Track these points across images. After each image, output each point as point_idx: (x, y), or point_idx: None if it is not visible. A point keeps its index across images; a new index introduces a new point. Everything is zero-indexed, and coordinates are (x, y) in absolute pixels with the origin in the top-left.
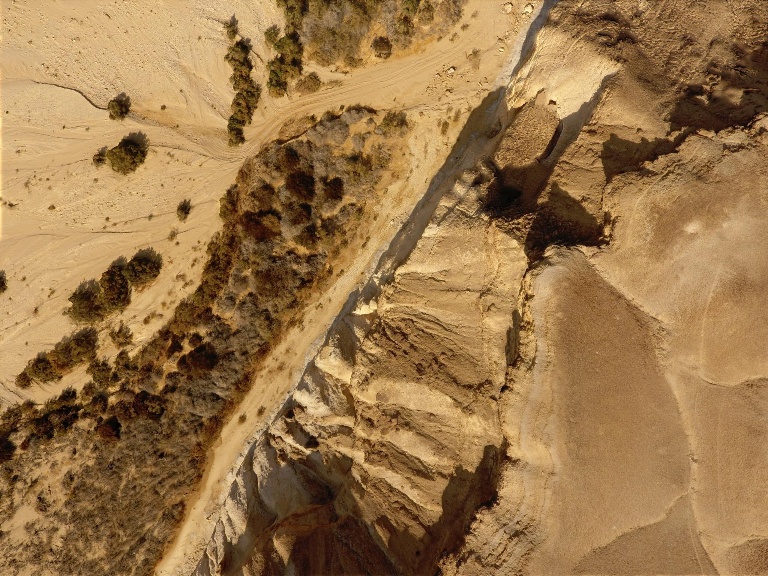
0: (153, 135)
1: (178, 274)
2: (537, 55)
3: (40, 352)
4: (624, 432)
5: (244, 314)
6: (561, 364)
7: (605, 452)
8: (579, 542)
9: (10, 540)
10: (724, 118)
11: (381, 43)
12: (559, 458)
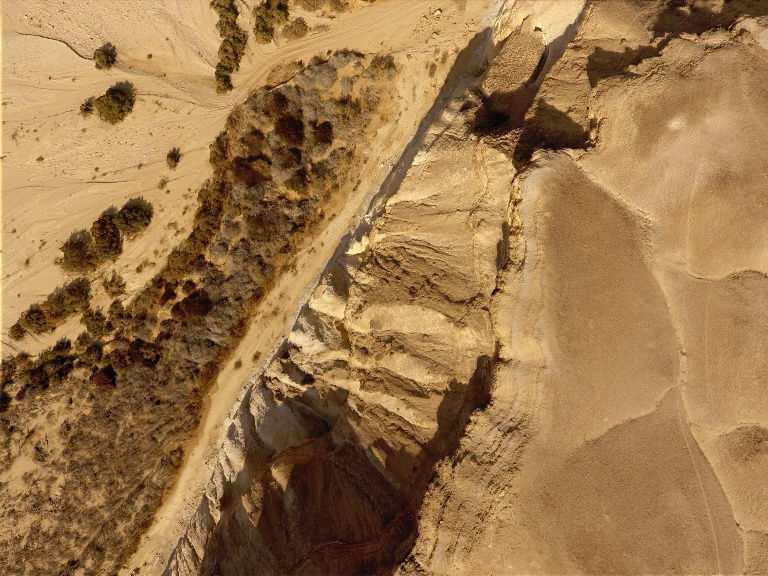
0: (140, 84)
1: (169, 222)
2: None
3: (33, 304)
4: (614, 326)
5: (237, 259)
6: (550, 259)
7: (595, 345)
8: (572, 434)
9: (8, 491)
10: (706, 19)
11: None
12: (550, 351)
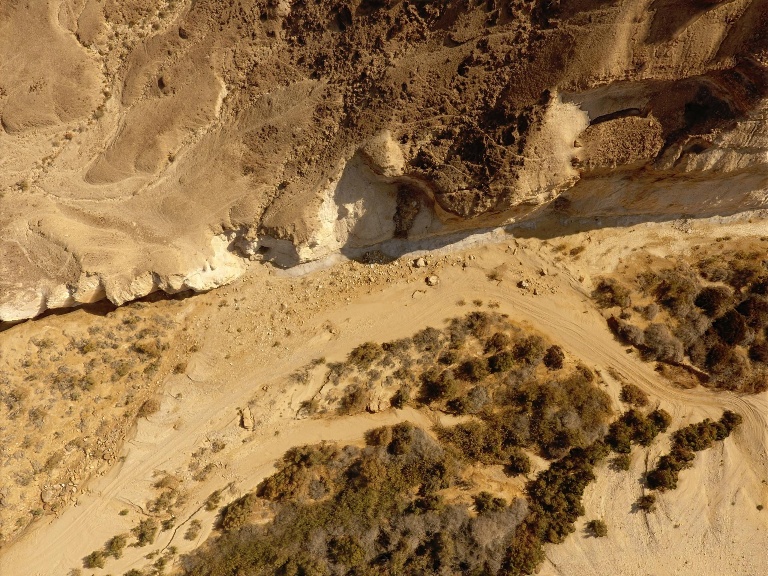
0: None
1: None
2: None
3: None
4: None
5: None
6: None
7: None
8: None
9: None
10: None
11: (554, 361)
12: None
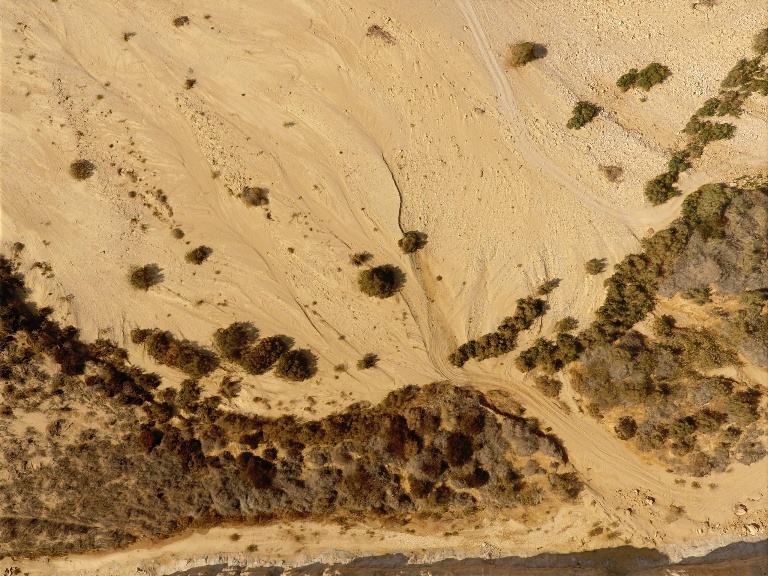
0: (410, 287)
1: (313, 397)
2: None
3: (170, 331)
4: None
5: (320, 482)
6: None
7: None
8: None
9: (10, 424)
10: None
11: (629, 427)
12: None
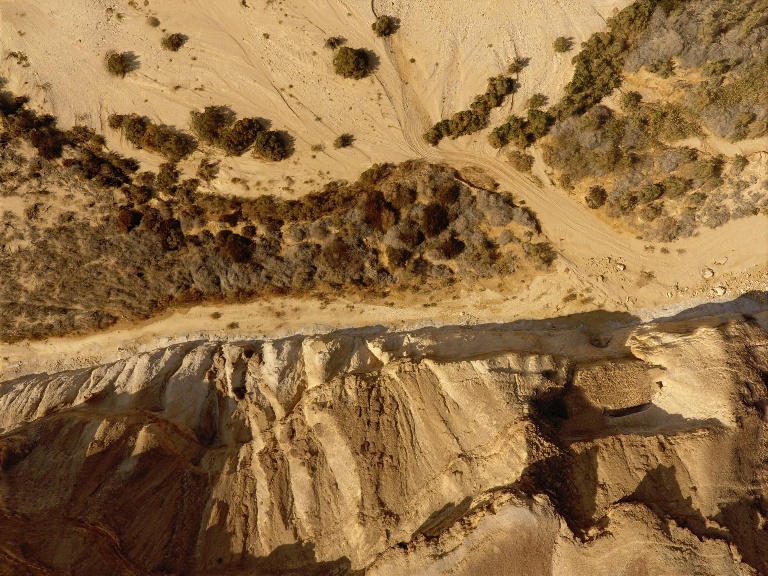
0: (385, 70)
1: (290, 176)
2: (689, 340)
3: (148, 116)
4: None
5: (299, 254)
6: None
7: None
8: None
9: None
10: (759, 559)
11: (599, 194)
12: None
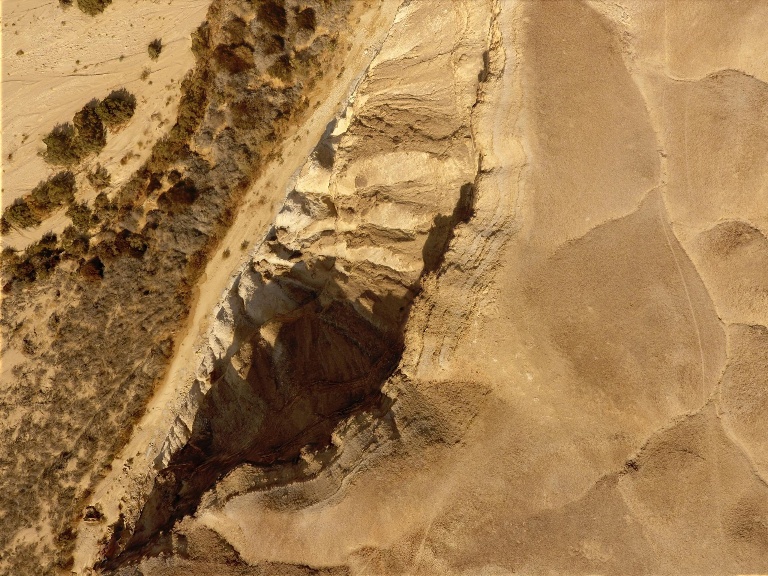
0: None
1: (153, 113)
2: None
3: (17, 198)
4: (594, 126)
5: (222, 147)
6: (529, 55)
7: (576, 144)
8: (554, 232)
9: None
10: None
11: None
12: (531, 148)
